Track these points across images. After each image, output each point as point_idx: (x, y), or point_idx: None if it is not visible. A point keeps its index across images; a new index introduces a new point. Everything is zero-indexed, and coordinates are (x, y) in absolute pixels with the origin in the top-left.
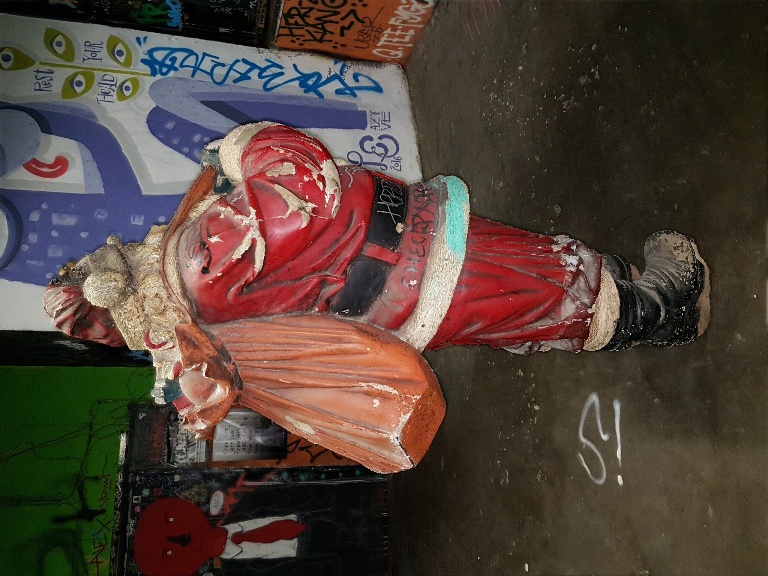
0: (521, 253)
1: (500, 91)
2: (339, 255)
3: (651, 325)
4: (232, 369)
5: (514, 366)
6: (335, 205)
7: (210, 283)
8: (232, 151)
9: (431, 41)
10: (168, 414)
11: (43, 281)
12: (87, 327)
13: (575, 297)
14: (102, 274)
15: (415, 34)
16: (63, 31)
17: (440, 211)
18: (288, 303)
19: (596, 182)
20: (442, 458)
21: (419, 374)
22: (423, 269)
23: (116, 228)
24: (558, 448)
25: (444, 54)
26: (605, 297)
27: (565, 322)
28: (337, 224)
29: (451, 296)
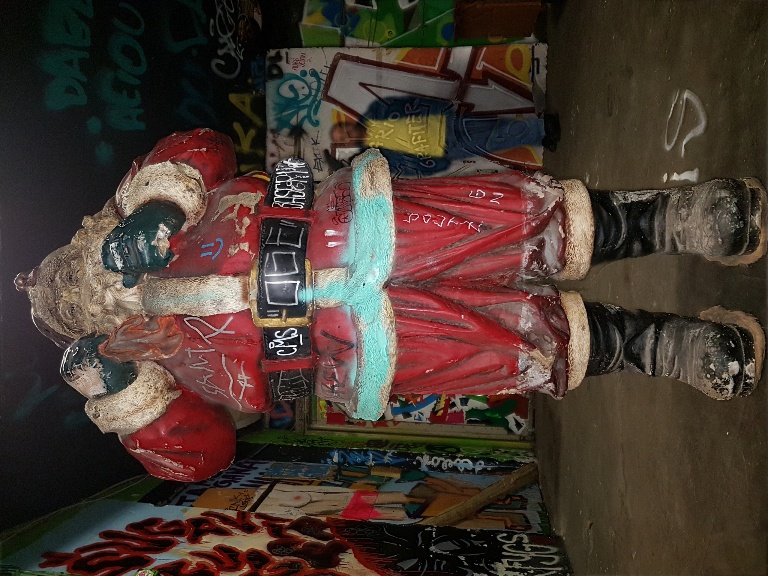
0: None
1: None
2: None
3: None
4: None
5: None
6: None
7: None
8: None
9: None
10: None
11: None
12: None
13: None
14: None
15: None
16: None
17: (351, 403)
18: None
19: None
20: None
21: None
22: None
23: None
24: (683, 36)
25: None
26: None
27: None
28: None
29: None
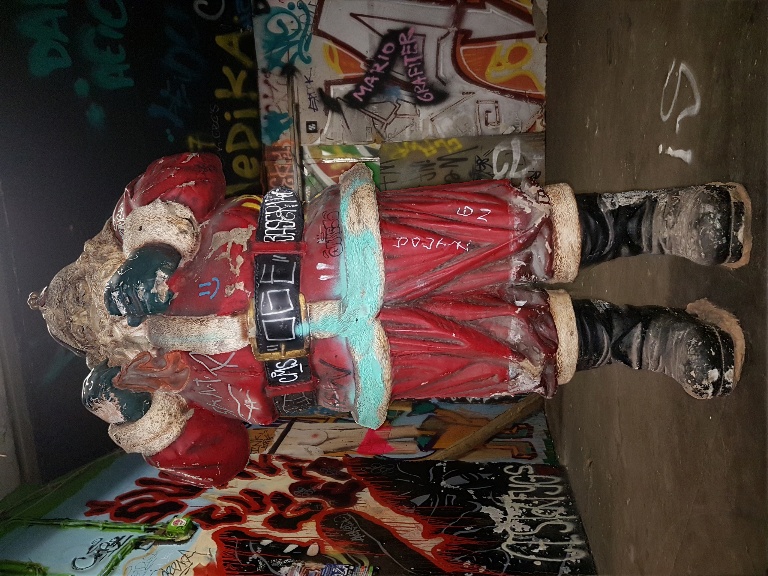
0: None
1: None
2: None
3: None
4: None
5: None
6: None
7: None
8: None
9: None
10: None
11: None
12: None
13: None
14: None
15: None
16: None
17: None
18: None
19: None
20: None
21: None
22: None
23: None
24: (680, 2)
25: None
26: None
27: None
28: None
29: None
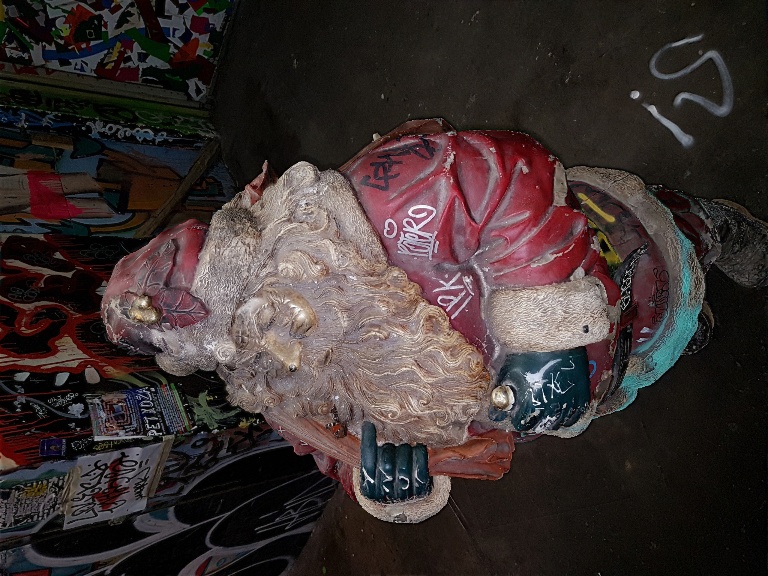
0: None
1: None
2: None
3: None
4: None
5: None
6: None
7: None
8: None
9: None
10: None
11: None
12: None
13: None
14: None
15: None
16: None
17: None
18: None
19: None
20: None
21: None
22: None
23: None
24: None
25: None
26: None
27: None
28: None
29: None
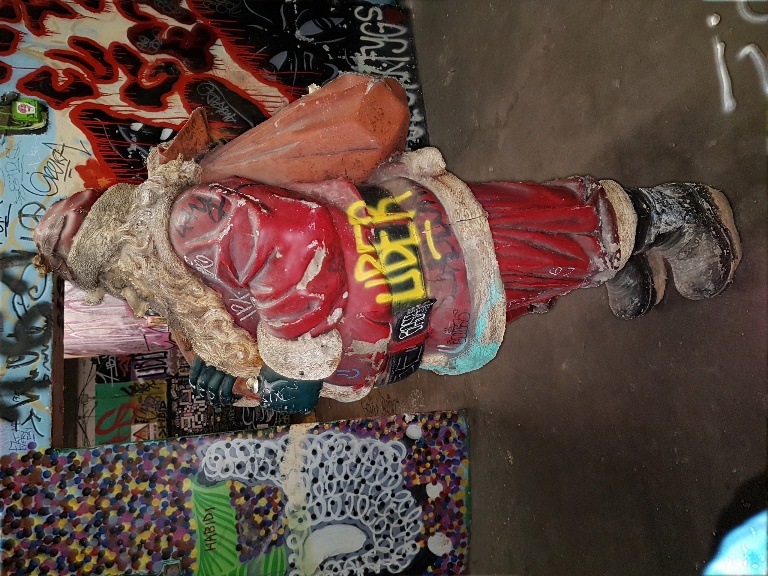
0: None
1: None
2: None
3: None
4: None
5: None
6: None
7: None
8: None
9: None
10: None
11: None
12: None
13: None
14: None
15: None
16: None
17: None
18: None
19: (764, 406)
20: None
21: None
22: None
23: None
24: None
25: None
26: None
27: None
28: None
29: None
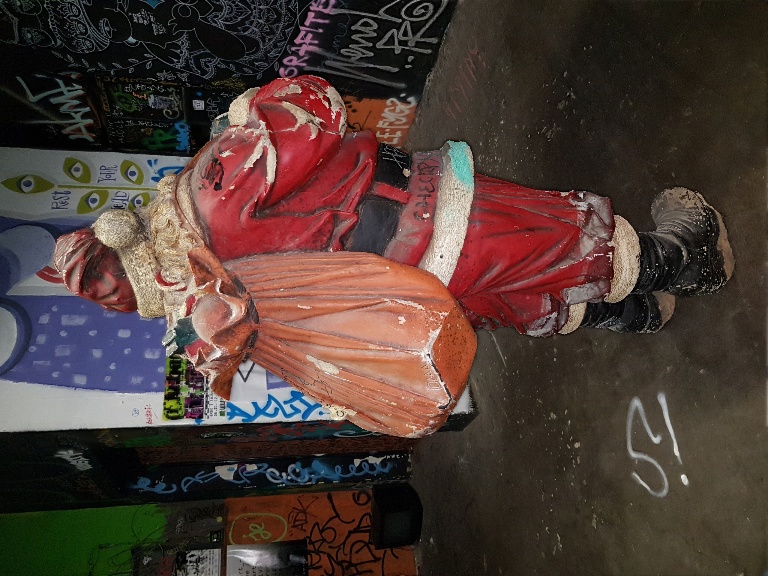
0: (530, 195)
1: (487, 150)
2: (349, 191)
3: (676, 266)
4: (247, 299)
5: (545, 412)
6: (342, 122)
7: (223, 200)
8: (240, 104)
9: (417, 137)
10: (176, 555)
11: (49, 380)
12: (97, 280)
13: (592, 234)
14: (114, 210)
15: (402, 136)
16: (81, 159)
17: (444, 159)
18: (302, 238)
19: (592, 188)
20: (483, 557)
21: (444, 292)
22: (434, 203)
23: (125, 325)
24: (609, 478)
25: (430, 143)
26: (622, 233)
27: (587, 258)
28: (345, 163)
29: (466, 224)
